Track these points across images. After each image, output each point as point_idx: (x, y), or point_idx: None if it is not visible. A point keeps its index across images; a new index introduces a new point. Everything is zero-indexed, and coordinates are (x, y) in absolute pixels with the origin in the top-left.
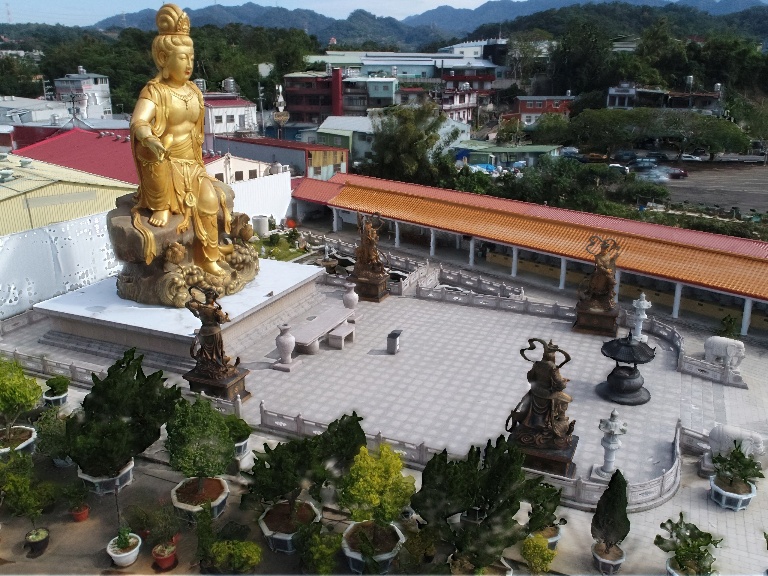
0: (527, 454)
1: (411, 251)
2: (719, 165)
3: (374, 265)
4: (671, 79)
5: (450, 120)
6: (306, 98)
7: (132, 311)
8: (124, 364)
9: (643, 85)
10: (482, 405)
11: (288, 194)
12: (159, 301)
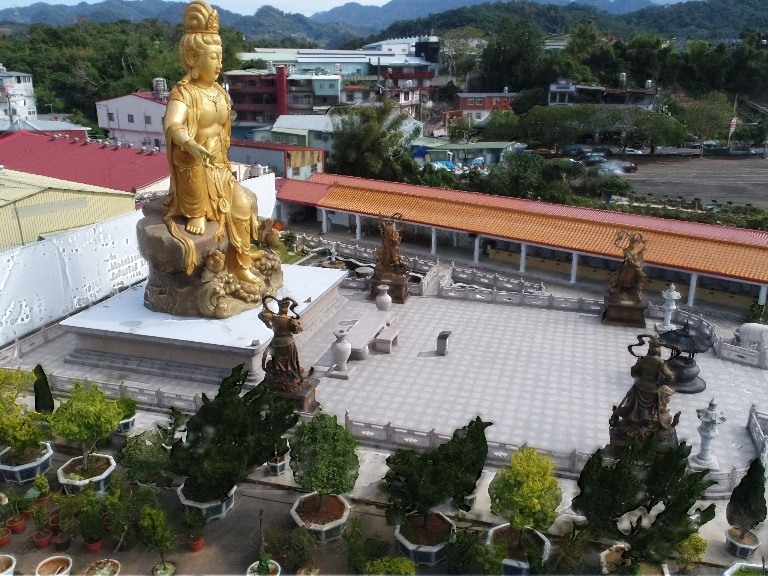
0: None
1: (411, 250)
2: (660, 158)
3: (396, 266)
4: (602, 76)
5: (411, 118)
6: (249, 96)
7: (172, 324)
8: (240, 382)
9: (578, 82)
10: (553, 402)
11: (273, 196)
12: (197, 312)
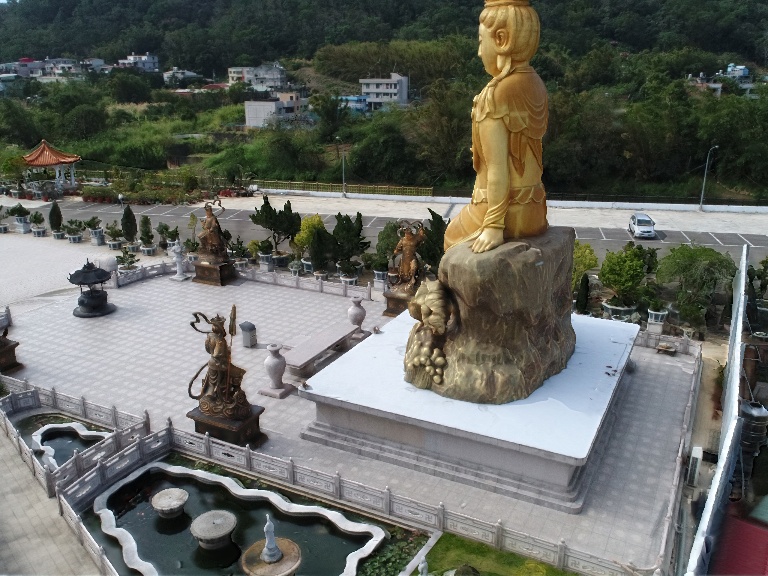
0: None
1: None
2: None
3: None
4: None
5: None
6: None
7: None
8: None
9: None
10: None
11: None
12: None
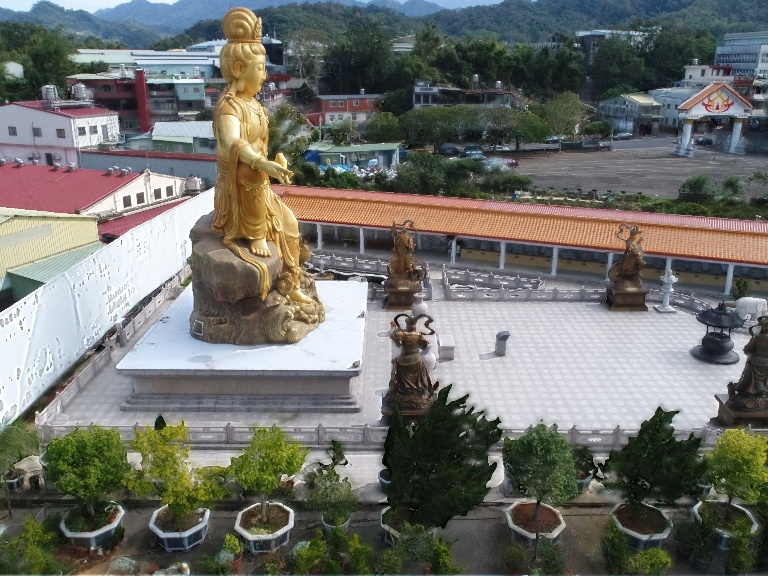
0: (754, 417)
1: (382, 256)
2: (526, 154)
3: (410, 273)
4: (451, 77)
5: (309, 122)
6: (104, 102)
7: (247, 355)
8: (464, 404)
9: None
10: (633, 386)
11: None
12: (266, 339)
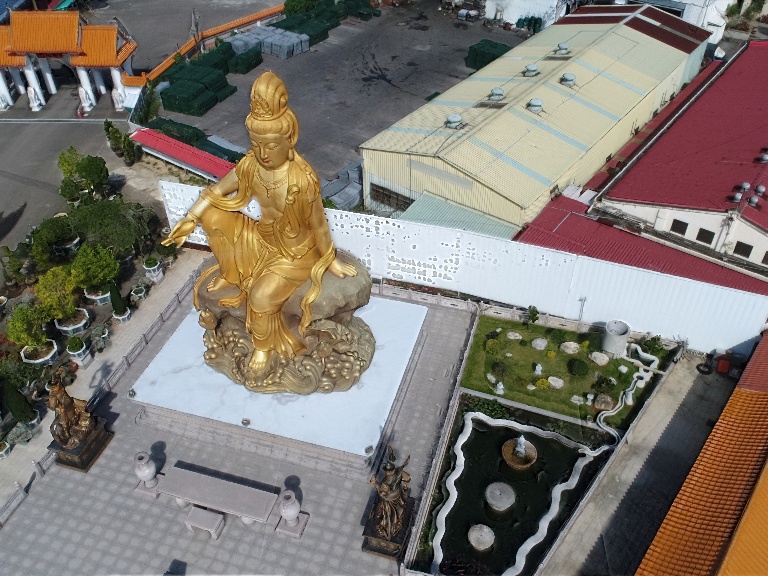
0: None
1: None
2: None
3: None
4: None
5: None
6: None
7: (201, 332)
8: None
9: None
10: None
11: (755, 325)
12: None
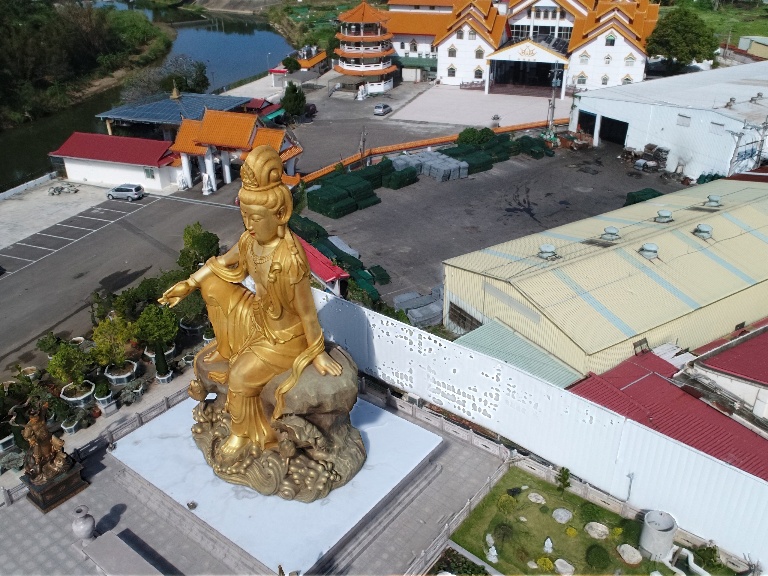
0: None
1: None
2: None
3: None
4: None
5: None
6: None
7: None
8: None
9: None
10: None
11: None
12: None
